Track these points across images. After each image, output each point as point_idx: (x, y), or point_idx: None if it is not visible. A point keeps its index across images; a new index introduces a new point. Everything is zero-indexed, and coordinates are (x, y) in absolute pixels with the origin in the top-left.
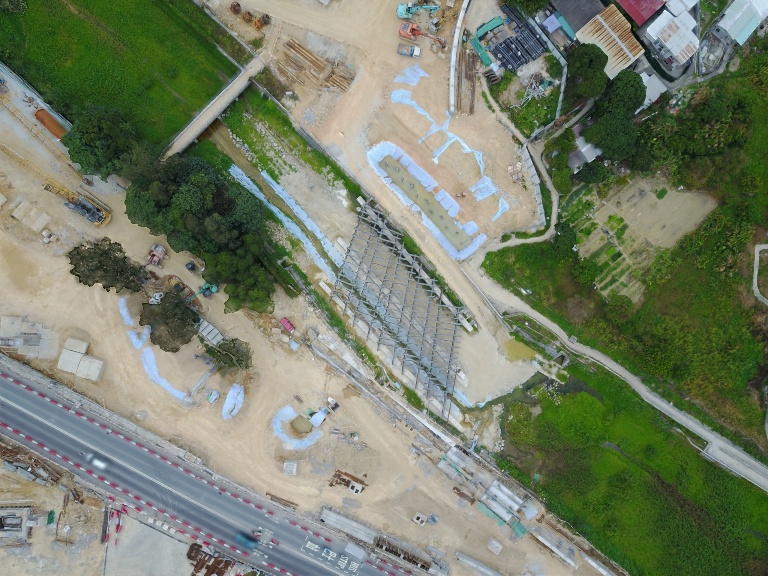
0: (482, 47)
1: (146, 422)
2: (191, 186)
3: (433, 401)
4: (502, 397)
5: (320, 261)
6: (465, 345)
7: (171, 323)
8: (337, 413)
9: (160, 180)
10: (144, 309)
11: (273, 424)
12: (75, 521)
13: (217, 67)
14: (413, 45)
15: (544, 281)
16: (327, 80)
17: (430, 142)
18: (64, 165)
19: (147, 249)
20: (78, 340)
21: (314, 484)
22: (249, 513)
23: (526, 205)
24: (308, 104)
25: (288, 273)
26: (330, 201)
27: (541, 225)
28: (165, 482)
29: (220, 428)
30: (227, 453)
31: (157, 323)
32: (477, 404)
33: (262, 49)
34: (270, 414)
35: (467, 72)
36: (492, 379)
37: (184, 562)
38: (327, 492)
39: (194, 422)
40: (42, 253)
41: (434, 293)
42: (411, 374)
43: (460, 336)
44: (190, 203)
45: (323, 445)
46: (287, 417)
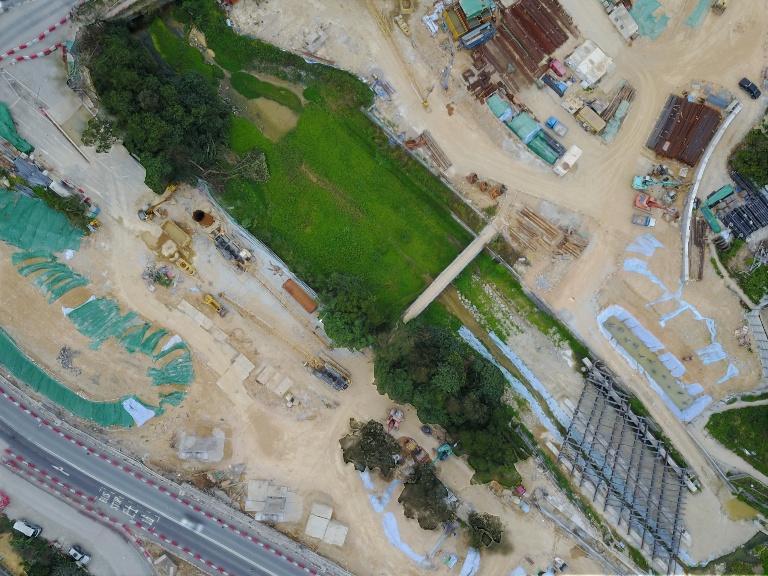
0: (712, 214)
1: None
2: (448, 366)
3: (658, 561)
4: (724, 556)
5: (546, 420)
6: (688, 504)
7: (435, 505)
8: (565, 573)
9: (425, 365)
10: (408, 490)
11: None
12: None
13: (447, 230)
14: (648, 216)
15: (767, 442)
16: (559, 247)
17: (659, 307)
18: (308, 332)
19: (383, 411)
20: (323, 505)
21: None
22: None
23: (755, 370)
24: (540, 270)
25: (519, 435)
26: (556, 361)
27: (766, 388)
28: None
29: None
30: None
31: (421, 505)
32: (700, 563)
33: (495, 216)
34: (503, 575)
35: (696, 238)
36: (715, 539)
37: None
38: None
39: None
40: (287, 418)
41: (659, 454)
42: (636, 534)
43: (686, 497)
44: (450, 385)
45: None
46: None
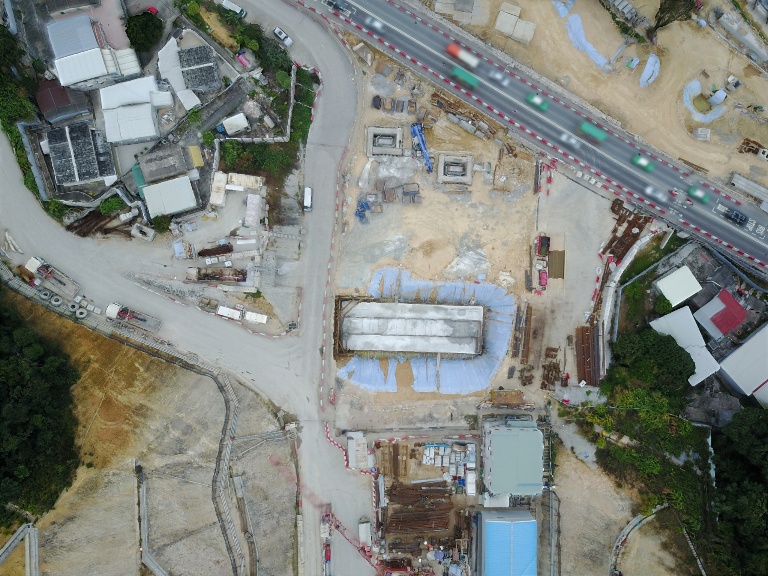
0: None
1: (569, 87)
2: None
3: None
4: None
5: None
6: None
7: None
8: (738, 91)
9: None
10: None
11: (685, 94)
12: (510, 173)
13: None
14: None
15: None
16: None
17: None
18: None
19: None
20: None
21: (724, 151)
22: (666, 174)
23: None
24: None
25: None
26: None
27: None
28: (590, 141)
29: (637, 95)
30: (643, 119)
31: None
32: None
33: None
34: (680, 86)
35: None
36: None
37: (607, 216)
38: (735, 159)
39: (613, 89)
40: None
41: None
42: None
43: None
44: None
45: (727, 119)
46: (693, 92)
